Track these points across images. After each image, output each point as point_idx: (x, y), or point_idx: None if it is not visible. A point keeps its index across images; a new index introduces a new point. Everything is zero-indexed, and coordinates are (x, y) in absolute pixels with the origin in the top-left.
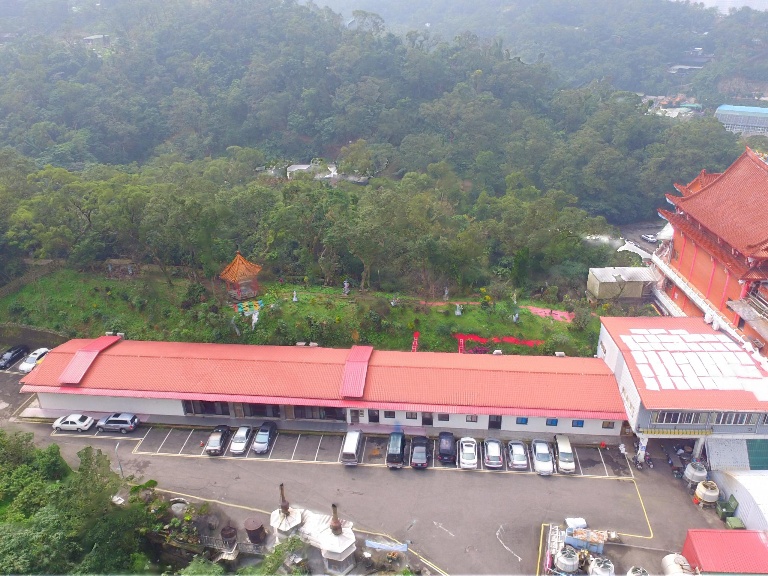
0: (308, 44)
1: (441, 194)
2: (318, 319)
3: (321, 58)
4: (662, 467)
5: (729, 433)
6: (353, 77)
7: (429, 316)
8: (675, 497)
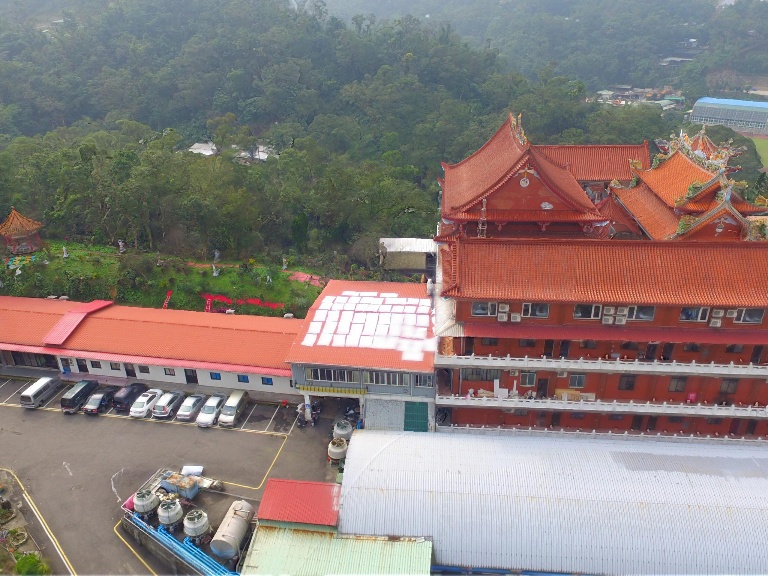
0: (244, 26)
1: (310, 170)
2: (76, 274)
3: (254, 40)
4: (325, 426)
5: (385, 394)
6: (284, 59)
7: (188, 276)
8: (313, 454)
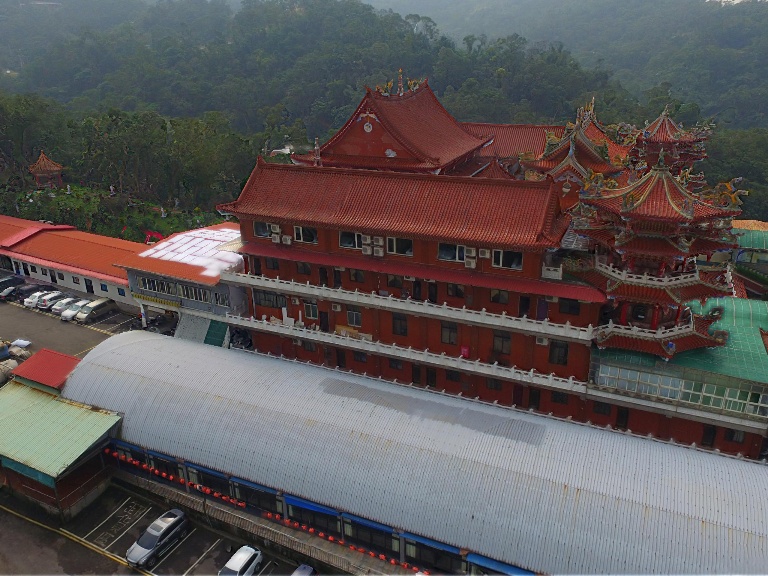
0: (355, 43)
1: None
2: (66, 206)
3: (360, 55)
4: None
5: (195, 309)
6: None
7: (145, 216)
8: None
